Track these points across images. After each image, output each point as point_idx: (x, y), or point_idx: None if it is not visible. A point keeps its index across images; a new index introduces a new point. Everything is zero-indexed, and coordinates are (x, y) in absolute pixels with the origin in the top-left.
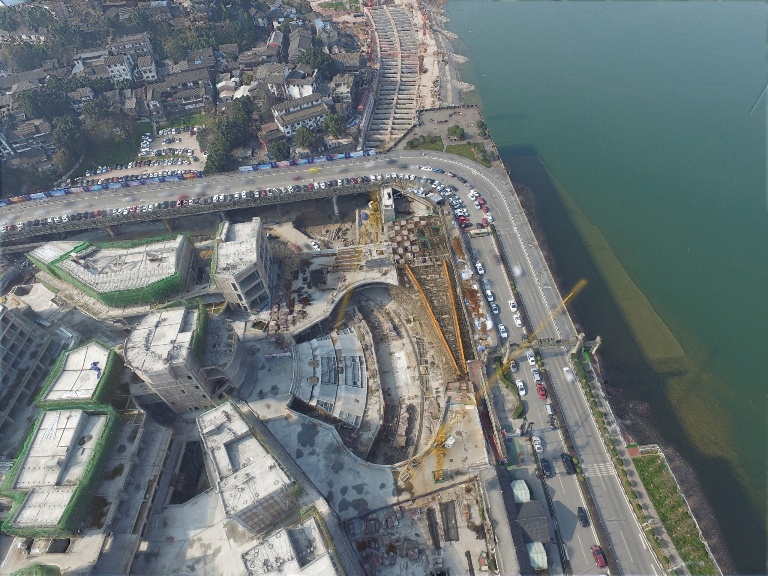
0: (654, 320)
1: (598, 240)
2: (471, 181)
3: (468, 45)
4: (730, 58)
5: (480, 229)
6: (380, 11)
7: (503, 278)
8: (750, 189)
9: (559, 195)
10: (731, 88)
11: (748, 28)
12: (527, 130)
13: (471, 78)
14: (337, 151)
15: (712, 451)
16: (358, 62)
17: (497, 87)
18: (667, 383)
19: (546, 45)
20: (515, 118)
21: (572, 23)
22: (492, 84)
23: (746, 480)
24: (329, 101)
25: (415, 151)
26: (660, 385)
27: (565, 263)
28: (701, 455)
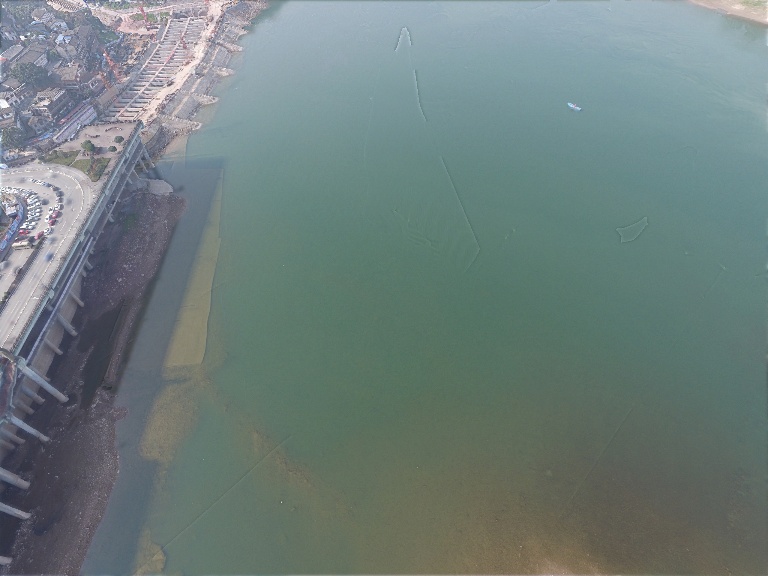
0: (200, 329)
1: (212, 252)
2: (67, 195)
3: (246, 58)
4: (477, 73)
5: (22, 242)
6: (180, 23)
7: (6, 289)
8: (367, 204)
9: (211, 207)
10: (450, 103)
11: (518, 43)
12: (232, 143)
13: (223, 91)
14: (16, 163)
15: (152, 454)
16: (74, 76)
17: (238, 100)
18: (164, 390)
19: (315, 59)
20: (230, 131)
21: (356, 37)
22: (236, 97)
23: (161, 482)
24: (28, 114)
25: (45, 165)
26: (156, 392)
27: (165, 274)
28: (139, 458)
